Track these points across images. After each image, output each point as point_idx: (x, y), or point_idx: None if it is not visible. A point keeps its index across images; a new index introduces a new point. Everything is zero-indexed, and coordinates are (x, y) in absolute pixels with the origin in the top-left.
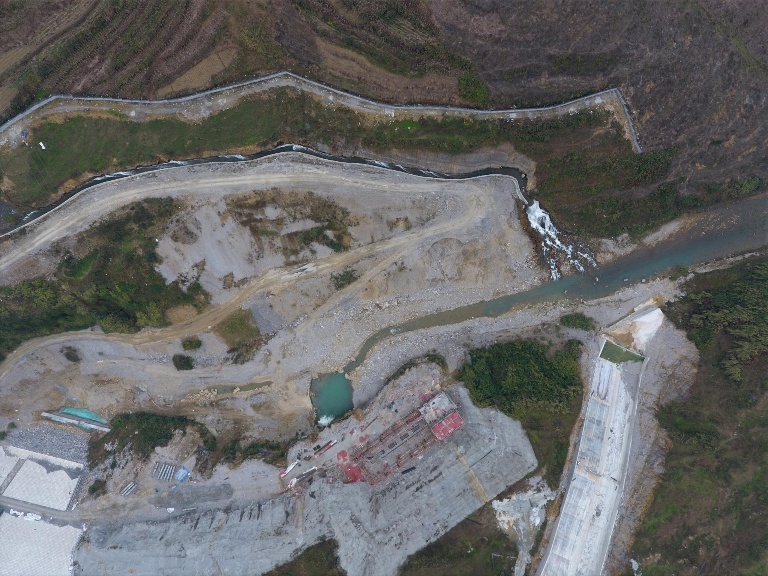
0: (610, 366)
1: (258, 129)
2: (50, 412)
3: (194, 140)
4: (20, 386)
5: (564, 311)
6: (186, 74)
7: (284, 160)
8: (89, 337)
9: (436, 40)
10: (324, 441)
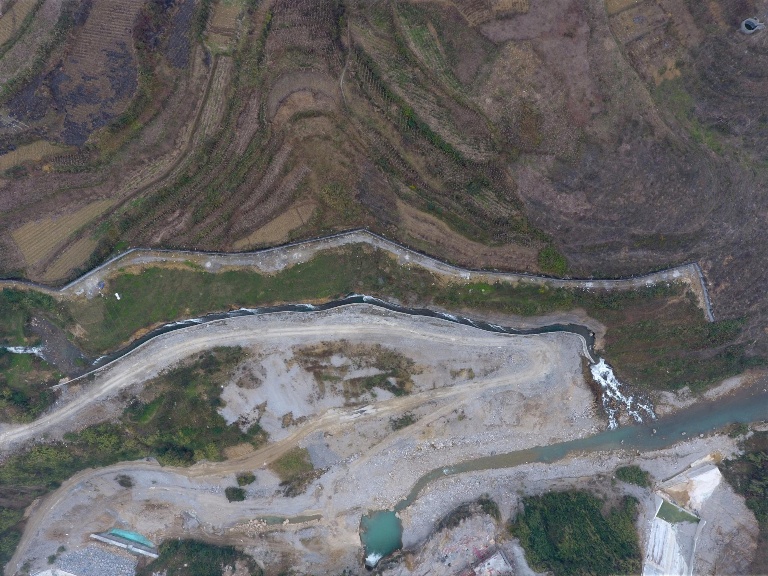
0: (665, 526)
1: (331, 283)
2: (99, 533)
3: (267, 291)
4: (72, 511)
5: (620, 462)
6: (264, 227)
7: (354, 311)
8: (144, 467)
9: (520, 214)
10: None
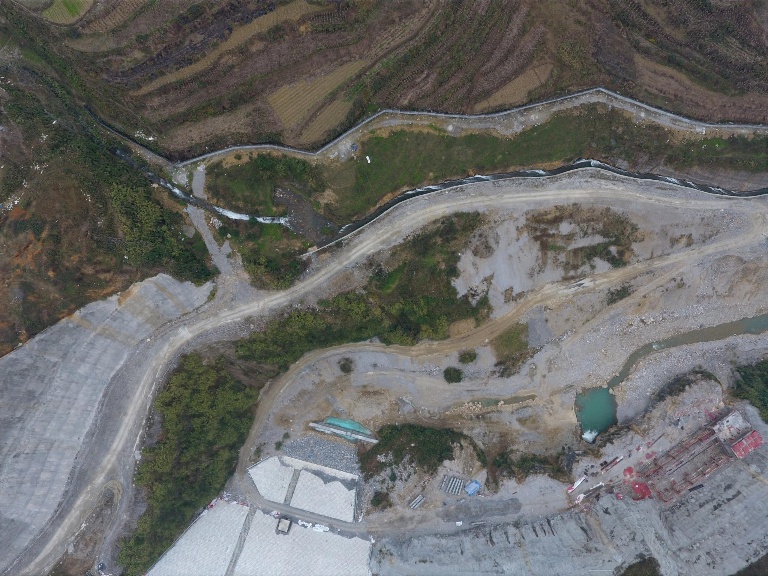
0: None
1: (566, 145)
2: (316, 422)
3: (504, 155)
4: (298, 396)
5: None
6: (503, 89)
7: (583, 176)
8: (368, 349)
9: (765, 59)
10: (610, 457)
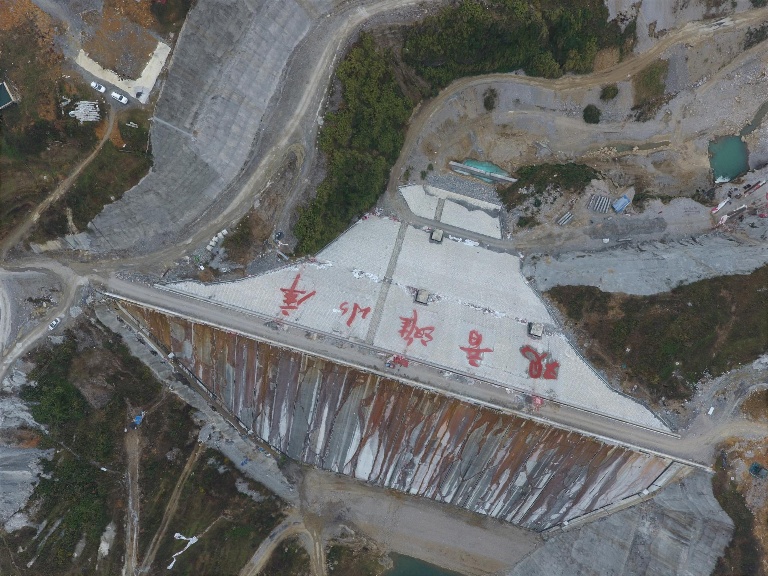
0: None
1: None
2: (456, 162)
3: None
4: (444, 126)
5: None
6: None
7: None
8: (513, 80)
9: None
10: (753, 181)
